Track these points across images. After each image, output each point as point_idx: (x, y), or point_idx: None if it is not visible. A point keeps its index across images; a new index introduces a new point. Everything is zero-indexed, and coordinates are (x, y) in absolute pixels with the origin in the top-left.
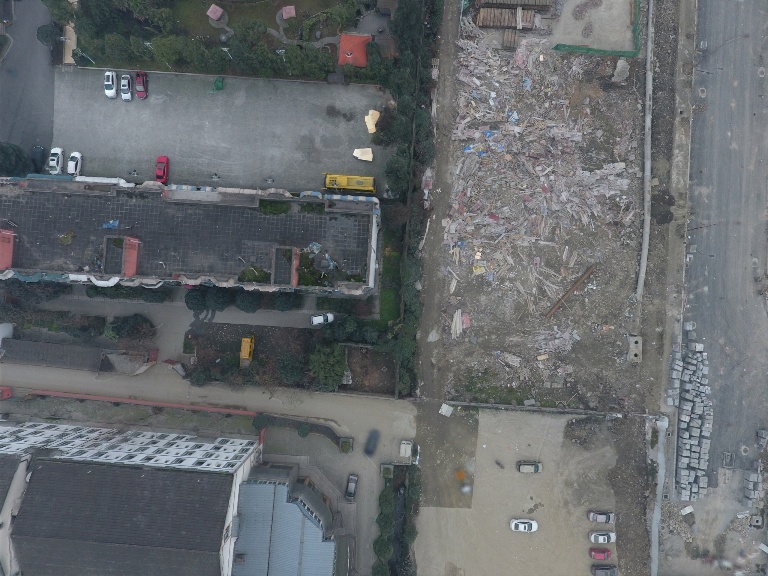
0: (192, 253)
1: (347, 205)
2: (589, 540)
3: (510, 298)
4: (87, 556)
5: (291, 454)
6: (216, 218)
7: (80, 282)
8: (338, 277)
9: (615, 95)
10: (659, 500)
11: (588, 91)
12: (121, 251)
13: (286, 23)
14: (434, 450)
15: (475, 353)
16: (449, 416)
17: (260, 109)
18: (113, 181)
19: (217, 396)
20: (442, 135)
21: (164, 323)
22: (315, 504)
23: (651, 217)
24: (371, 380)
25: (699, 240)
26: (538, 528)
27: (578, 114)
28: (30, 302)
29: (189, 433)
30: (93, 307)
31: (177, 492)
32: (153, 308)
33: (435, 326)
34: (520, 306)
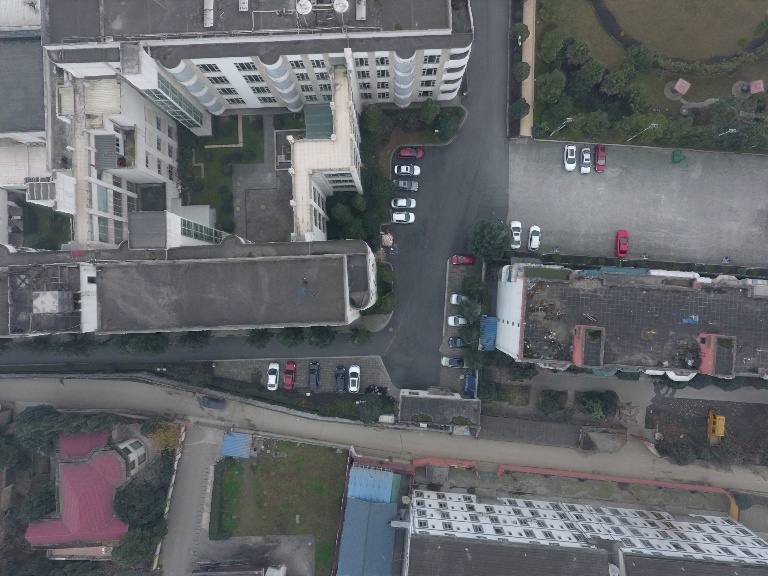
0: None
1: None
2: None
3: None
4: None
5: (759, 531)
6: None
7: None
8: None
9: None
10: None
11: None
12: (727, 351)
13: (743, 96)
14: None
15: None
16: None
17: (716, 182)
18: (687, 275)
19: (681, 472)
20: None
21: (626, 398)
22: None
23: None
24: None
25: None
26: None
27: None
28: (516, 380)
29: (656, 509)
30: (554, 381)
31: None
32: (614, 383)
33: None
34: None
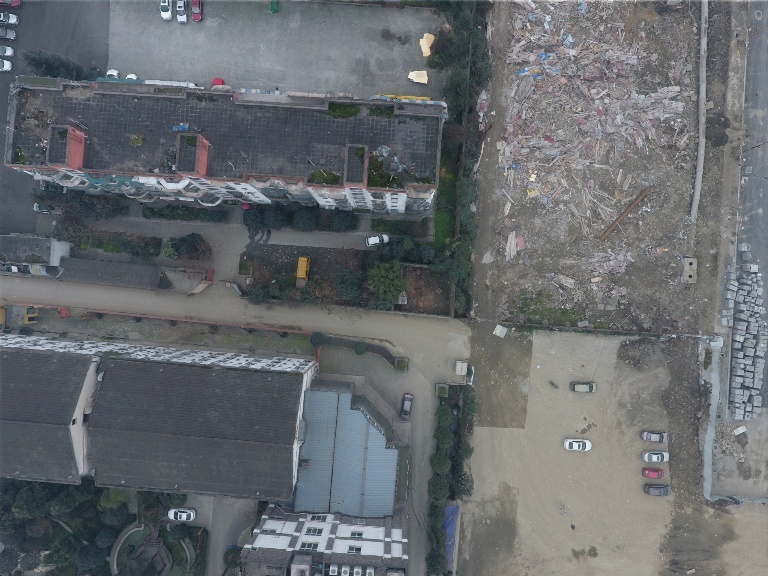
0: (262, 155)
1: (416, 109)
2: (642, 459)
3: (564, 221)
4: (161, 450)
5: (346, 374)
6: (285, 121)
7: (141, 196)
8: (408, 178)
9: (670, 19)
10: (713, 419)
11: (643, 15)
12: (194, 149)
13: None
14: (488, 371)
15: (529, 275)
16: (503, 337)
17: (315, 32)
18: (182, 85)
19: (273, 316)
20: (497, 58)
21: (220, 244)
22: (376, 416)
23: (706, 140)
24: (426, 301)
25: (754, 162)
26: (592, 447)
27: (633, 37)
28: (89, 219)
29: (245, 353)
30: (149, 228)
31: (249, 390)
32: (209, 229)
33: (489, 248)
34: (574, 229)
